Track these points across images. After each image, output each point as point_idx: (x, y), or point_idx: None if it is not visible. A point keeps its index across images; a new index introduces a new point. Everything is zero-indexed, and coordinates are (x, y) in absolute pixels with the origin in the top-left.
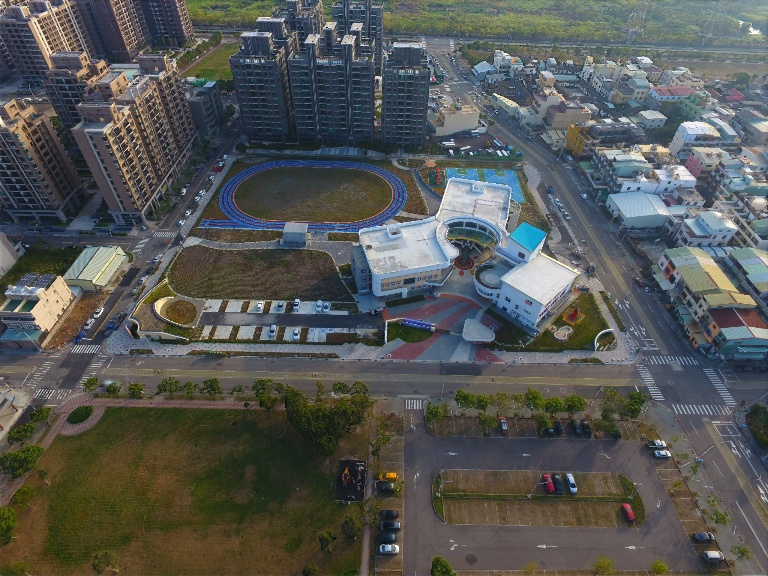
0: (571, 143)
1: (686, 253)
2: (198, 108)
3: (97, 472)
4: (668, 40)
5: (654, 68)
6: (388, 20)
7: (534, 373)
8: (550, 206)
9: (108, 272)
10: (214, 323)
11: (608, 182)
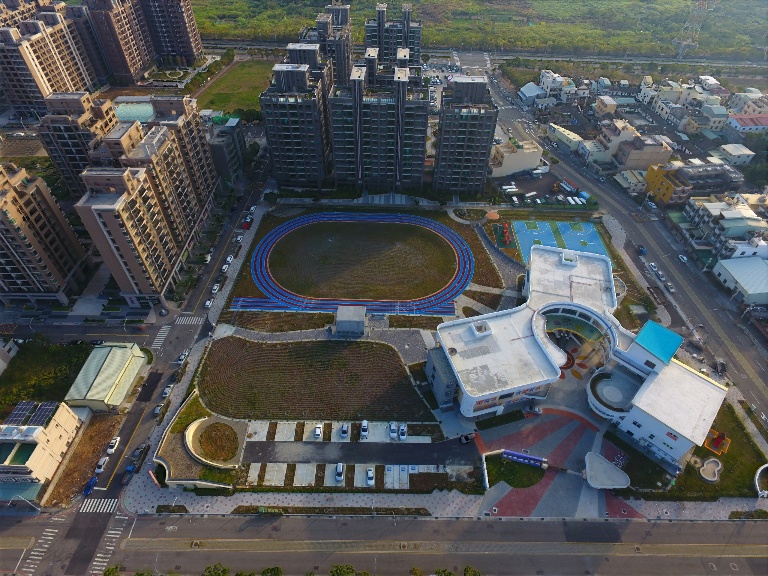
0: (653, 187)
1: None
2: (220, 152)
3: None
4: (723, 54)
5: (721, 89)
6: None
7: (689, 537)
8: (646, 273)
9: (123, 384)
10: (262, 459)
11: (713, 243)
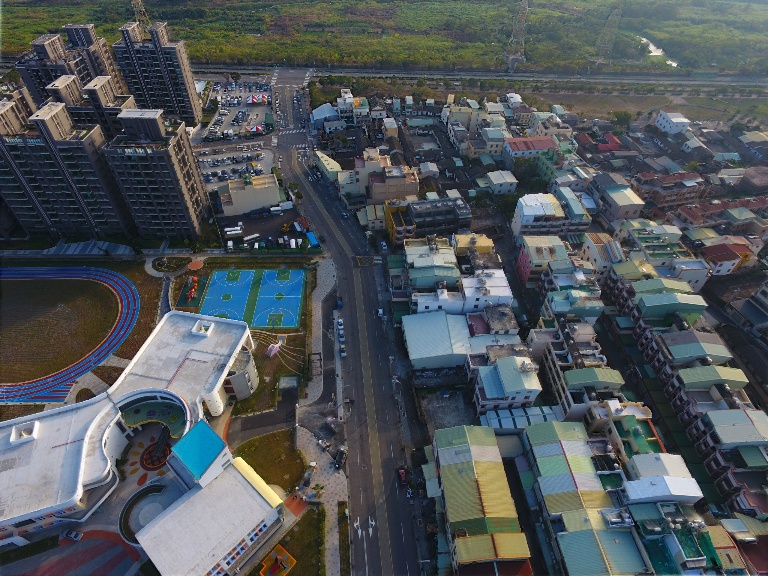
0: (388, 225)
1: (460, 439)
2: None
3: None
4: (554, 67)
5: (523, 108)
6: (249, 46)
7: None
8: (328, 332)
9: None
10: None
11: (408, 294)
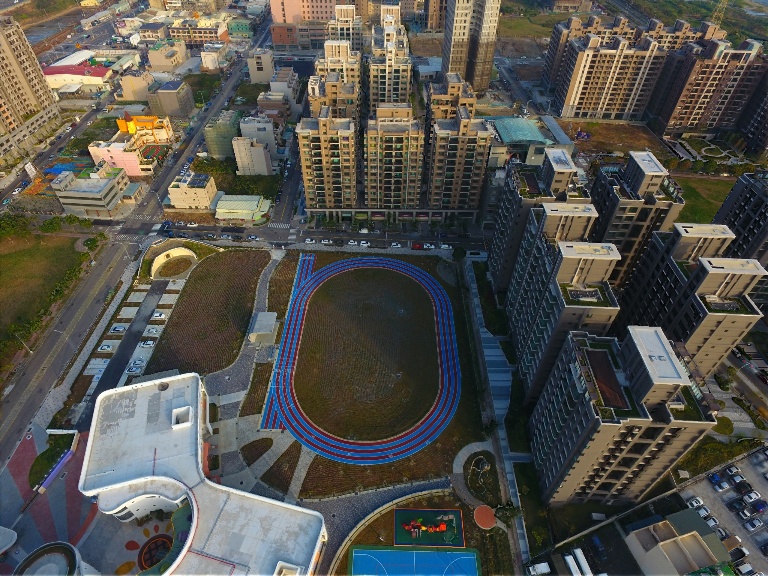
0: None
1: None
2: None
3: (36, 261)
4: None
5: None
6: None
7: None
8: None
9: (231, 215)
10: (151, 289)
11: None
